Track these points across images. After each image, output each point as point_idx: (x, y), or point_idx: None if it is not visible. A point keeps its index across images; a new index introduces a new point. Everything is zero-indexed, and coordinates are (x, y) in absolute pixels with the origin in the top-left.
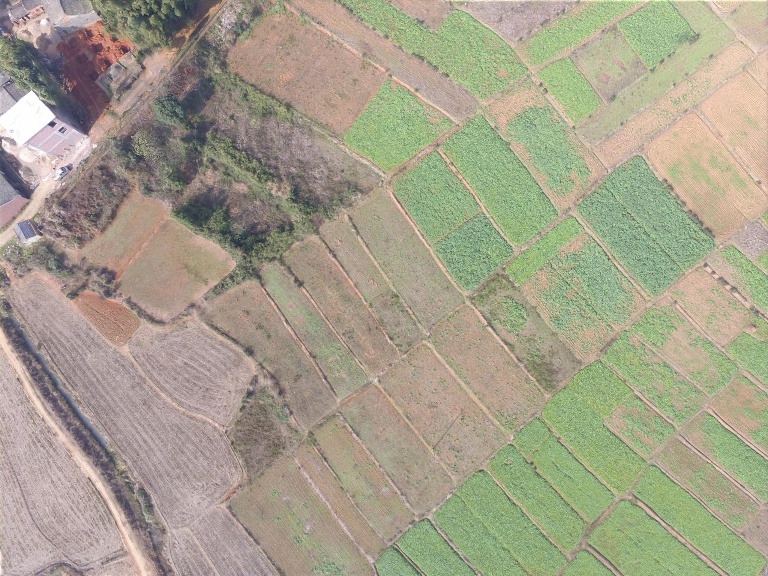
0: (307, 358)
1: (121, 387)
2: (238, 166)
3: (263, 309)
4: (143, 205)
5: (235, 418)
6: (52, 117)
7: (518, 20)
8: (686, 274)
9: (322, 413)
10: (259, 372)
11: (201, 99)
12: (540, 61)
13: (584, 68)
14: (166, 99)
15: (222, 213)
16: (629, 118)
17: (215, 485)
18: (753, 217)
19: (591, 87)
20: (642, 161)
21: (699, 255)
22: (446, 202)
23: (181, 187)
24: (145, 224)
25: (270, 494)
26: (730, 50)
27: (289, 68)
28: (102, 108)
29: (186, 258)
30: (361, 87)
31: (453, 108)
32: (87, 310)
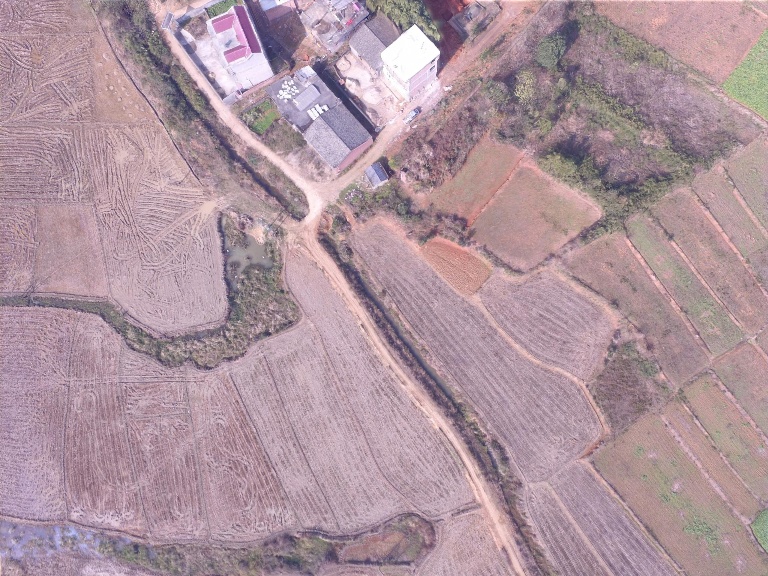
0: (676, 313)
1: (471, 337)
2: (613, 112)
3: (627, 262)
4: (494, 151)
5: (596, 372)
6: (437, 53)
7: None
8: None
9: (694, 370)
10: (623, 326)
11: (566, 42)
12: None
13: None
14: (559, 37)
15: (592, 160)
16: None
17: (574, 440)
18: None
19: None
20: None
21: None
22: None
23: (545, 133)
24: (497, 171)
25: (635, 451)
26: None
27: (662, 12)
28: (455, 49)
29: (543, 207)
30: (740, 34)
31: None
32: (434, 258)
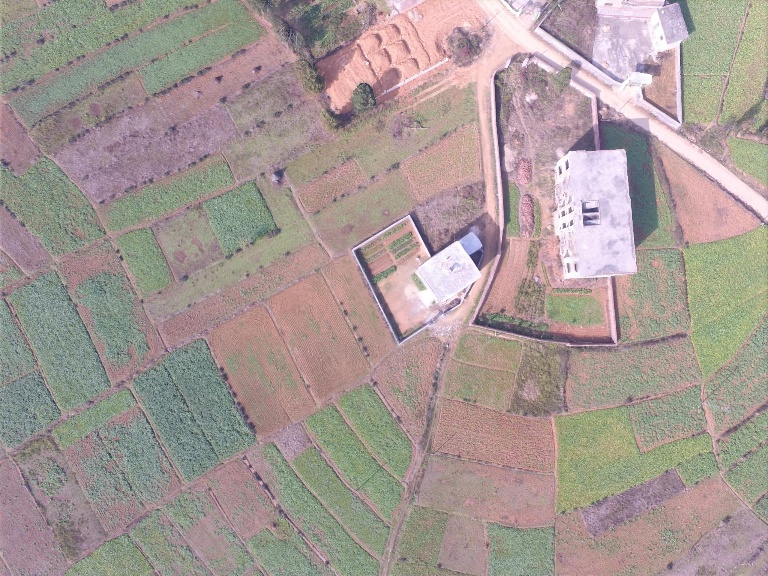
0: None
1: None
2: None
3: None
4: None
5: None
6: None
7: (104, 181)
8: (225, 463)
9: None
10: None
11: None
12: (118, 228)
13: (163, 242)
14: None
15: None
16: (198, 301)
17: None
18: (296, 419)
19: (166, 263)
20: (204, 346)
21: (238, 448)
22: (4, 354)
23: None
24: None
25: None
26: (307, 250)
27: None
28: None
29: None
30: None
31: (25, 260)
32: None
